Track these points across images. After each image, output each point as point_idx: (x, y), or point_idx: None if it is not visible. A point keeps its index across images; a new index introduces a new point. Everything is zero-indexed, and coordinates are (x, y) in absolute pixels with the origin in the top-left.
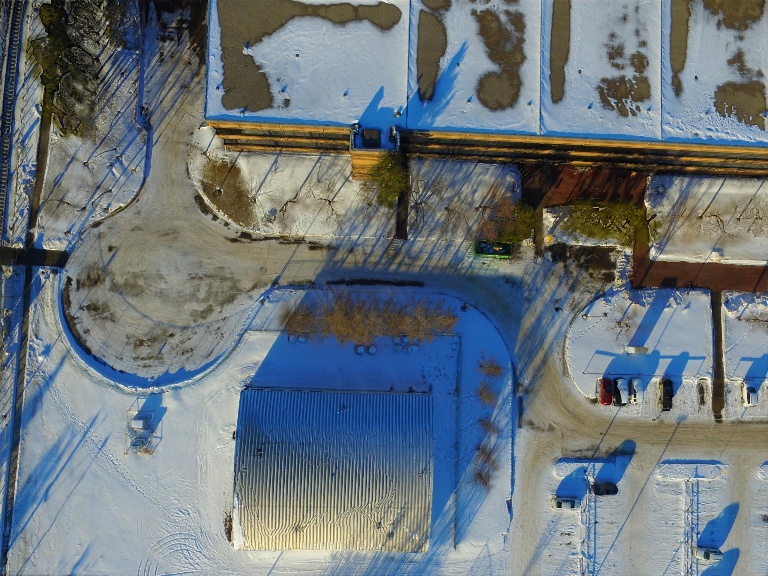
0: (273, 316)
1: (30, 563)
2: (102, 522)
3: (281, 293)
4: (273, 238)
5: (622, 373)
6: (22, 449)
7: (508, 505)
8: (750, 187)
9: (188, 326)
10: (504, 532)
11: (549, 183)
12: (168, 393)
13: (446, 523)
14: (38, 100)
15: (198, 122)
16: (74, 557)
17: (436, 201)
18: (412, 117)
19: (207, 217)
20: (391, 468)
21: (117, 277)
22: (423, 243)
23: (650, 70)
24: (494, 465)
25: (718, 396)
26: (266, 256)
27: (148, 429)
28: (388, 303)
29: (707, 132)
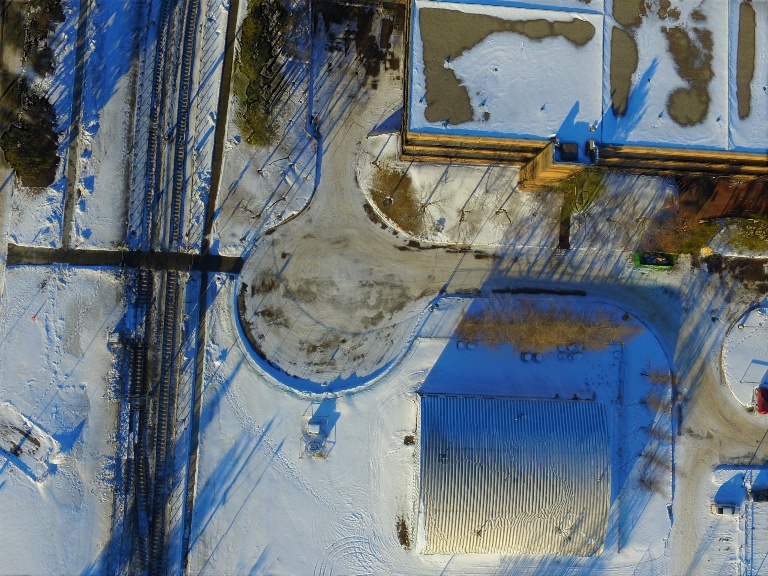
0: (442, 323)
1: (209, 565)
2: (278, 525)
3: (449, 301)
4: (440, 247)
5: None
6: (201, 452)
7: (669, 511)
8: None
9: (359, 332)
10: (665, 537)
11: (705, 195)
12: (342, 398)
13: (610, 528)
14: (213, 108)
15: (365, 132)
16: (252, 559)
17: (598, 212)
18: (607, 131)
19: (376, 225)
20: (571, 474)
21: (291, 284)
22: (585, 253)
23: None
24: (655, 471)
25: None
26: (434, 264)
27: (322, 434)
28: (552, 312)
29: None
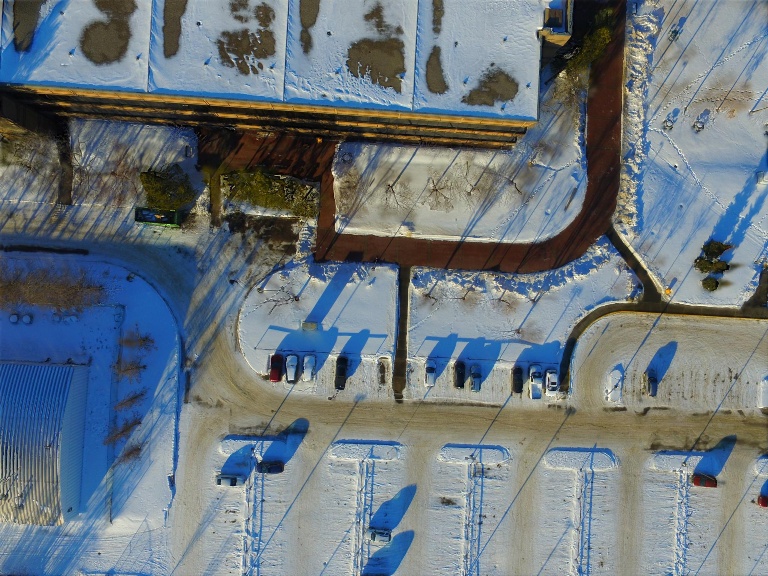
0: None
1: None
2: None
3: None
4: None
5: (293, 349)
6: None
7: (170, 481)
8: (445, 157)
9: None
10: (164, 508)
11: (228, 148)
12: None
13: (102, 497)
14: None
15: None
16: None
17: (101, 165)
18: (6, 70)
19: None
20: (16, 440)
21: None
22: (89, 209)
23: (276, 24)
24: (156, 440)
25: (399, 376)
26: None
27: None
28: (47, 271)
29: (335, 93)
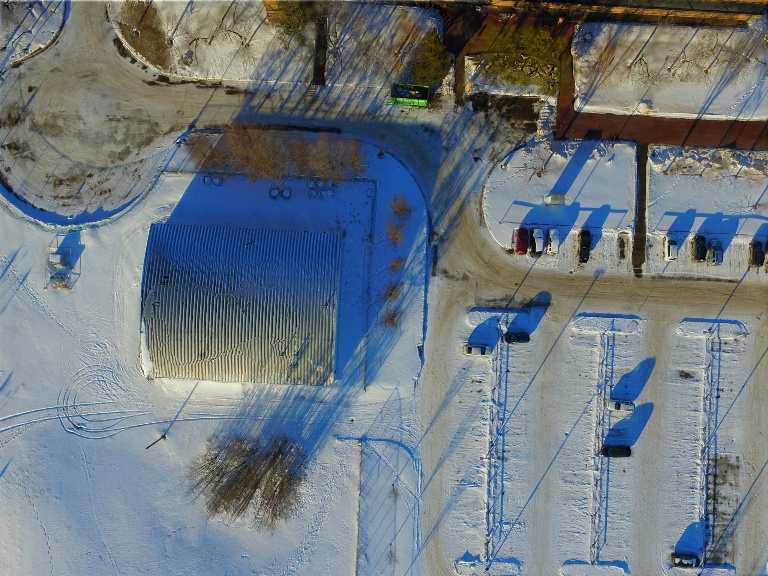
0: (189, 158)
1: None
2: (23, 352)
3: (197, 136)
4: (190, 82)
5: (539, 223)
6: None
7: (419, 351)
8: (683, 36)
9: (106, 167)
10: (415, 377)
11: (472, 30)
12: (86, 230)
13: (357, 365)
14: None
15: None
16: None
17: (354, 46)
18: None
19: (125, 60)
20: (295, 299)
21: (37, 117)
22: (341, 89)
23: None
24: (406, 311)
25: (639, 250)
26: (183, 99)
27: (67, 265)
28: (304, 148)
29: None
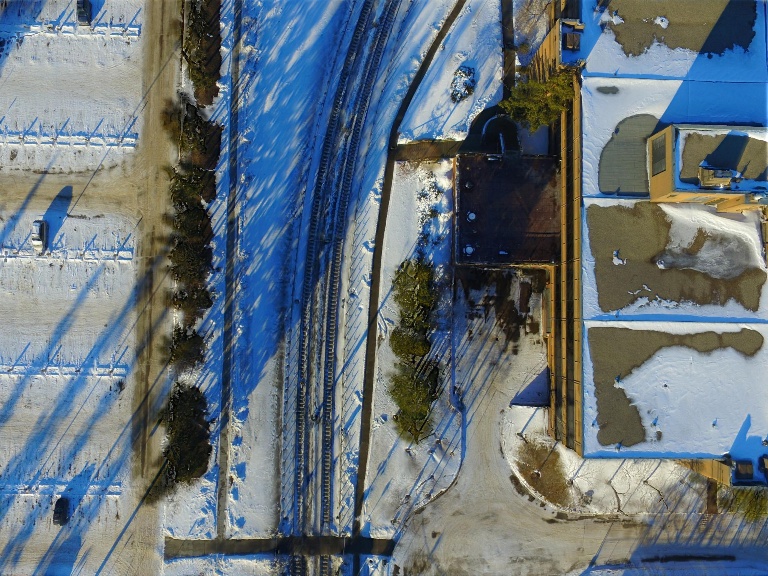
0: None
1: None
2: None
3: (599, 574)
4: (588, 517)
5: None
6: None
7: None
8: None
9: None
10: None
11: None
12: None
13: None
14: (358, 387)
15: (508, 399)
16: None
17: None
18: None
19: (523, 498)
20: None
21: (442, 563)
22: (732, 516)
23: None
24: None
25: None
26: (582, 536)
27: None
28: None
29: None
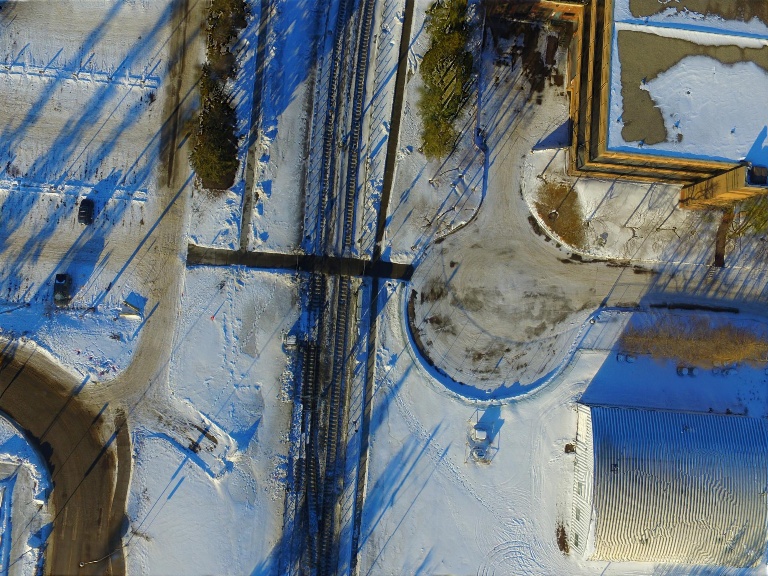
0: (603, 336)
1: (377, 565)
2: (443, 528)
3: (609, 314)
4: (601, 261)
5: None
6: (371, 455)
7: None
8: None
9: (523, 342)
10: None
11: None
12: (506, 406)
13: None
14: (386, 118)
15: (530, 146)
16: (418, 561)
17: (754, 232)
18: None
19: (540, 238)
20: (736, 487)
21: (458, 292)
22: (738, 271)
23: None
24: None
25: None
26: (595, 278)
27: (486, 440)
28: (708, 327)
29: None
